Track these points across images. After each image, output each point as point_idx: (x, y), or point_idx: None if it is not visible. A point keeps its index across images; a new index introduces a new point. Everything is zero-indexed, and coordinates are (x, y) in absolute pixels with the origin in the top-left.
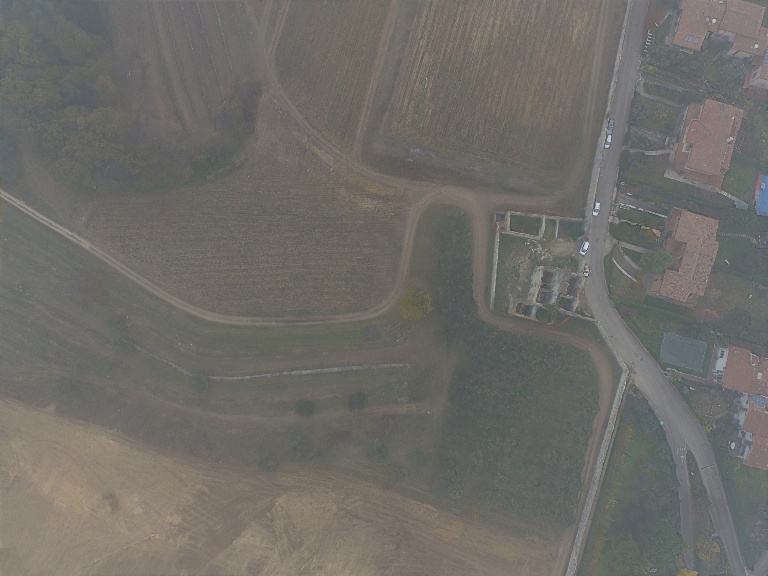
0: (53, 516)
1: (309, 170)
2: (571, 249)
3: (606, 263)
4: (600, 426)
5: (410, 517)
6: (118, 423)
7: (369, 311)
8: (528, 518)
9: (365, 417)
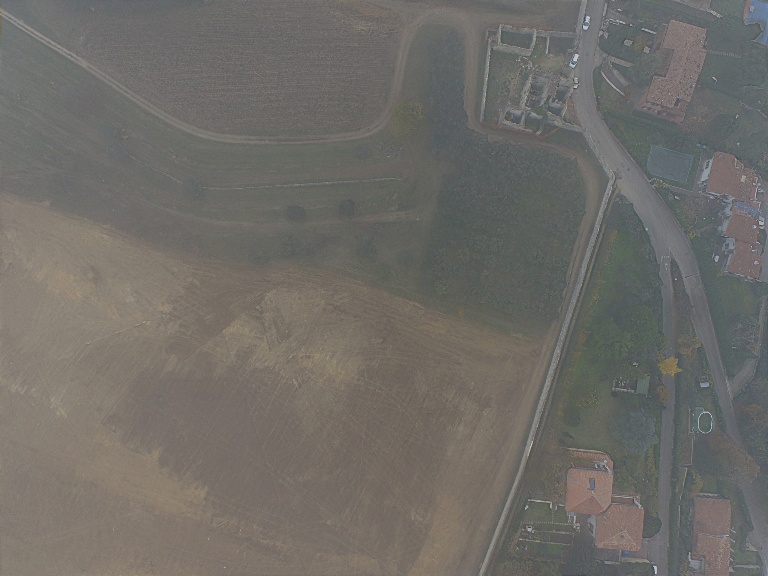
0: (46, 301)
1: None
2: (561, 63)
3: (595, 74)
4: (586, 232)
5: (397, 313)
6: (112, 221)
7: (361, 131)
8: (513, 317)
9: (355, 226)
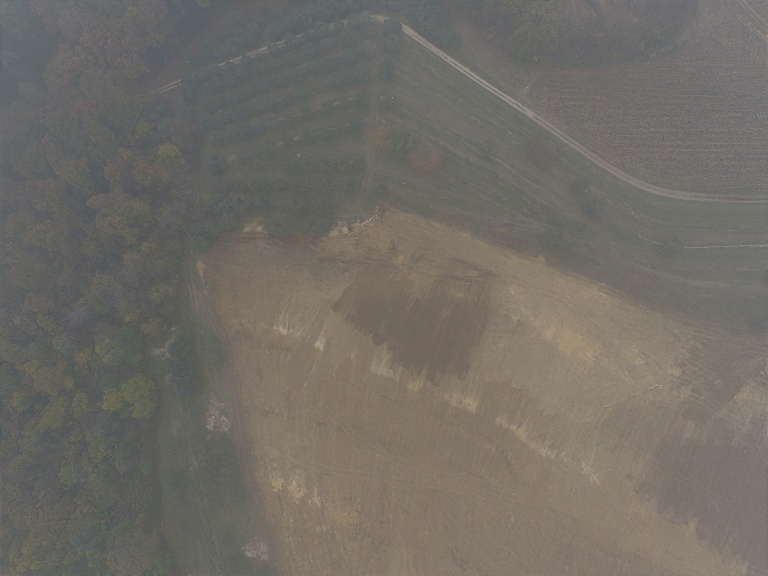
0: (559, 361)
1: (752, 53)
2: None
3: None
4: None
5: None
6: (603, 278)
7: None
8: None
9: None
